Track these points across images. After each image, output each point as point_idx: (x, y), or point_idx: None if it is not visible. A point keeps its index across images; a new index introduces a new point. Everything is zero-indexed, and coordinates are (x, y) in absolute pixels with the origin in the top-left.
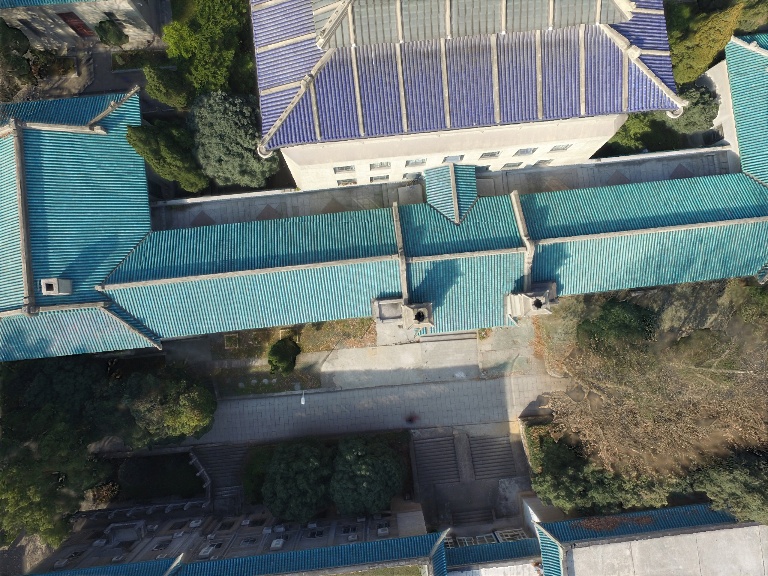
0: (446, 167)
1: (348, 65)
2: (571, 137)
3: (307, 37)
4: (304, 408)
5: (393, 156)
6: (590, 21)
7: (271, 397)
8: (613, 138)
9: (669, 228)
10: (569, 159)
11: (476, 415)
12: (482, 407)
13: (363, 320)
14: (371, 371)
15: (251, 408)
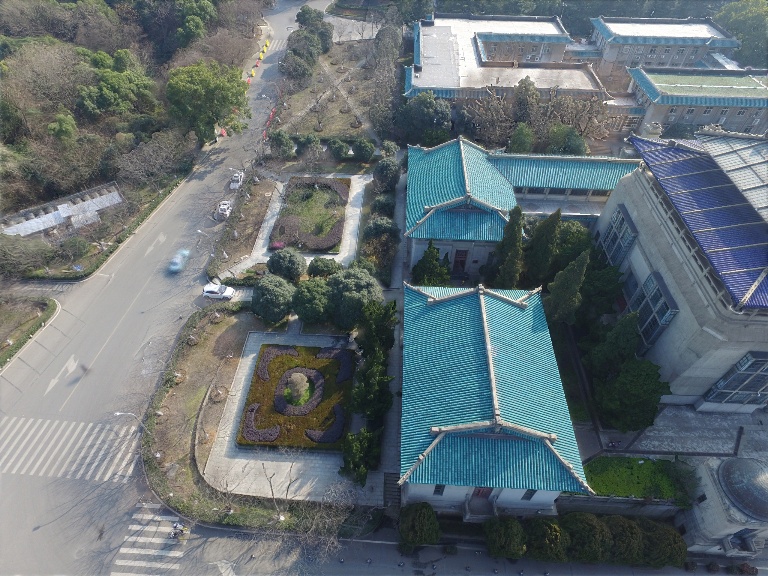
0: None
1: None
2: None
3: None
4: None
5: None
6: None
7: None
8: None
9: (572, 157)
10: None
11: None
12: None
13: None
14: None
15: None
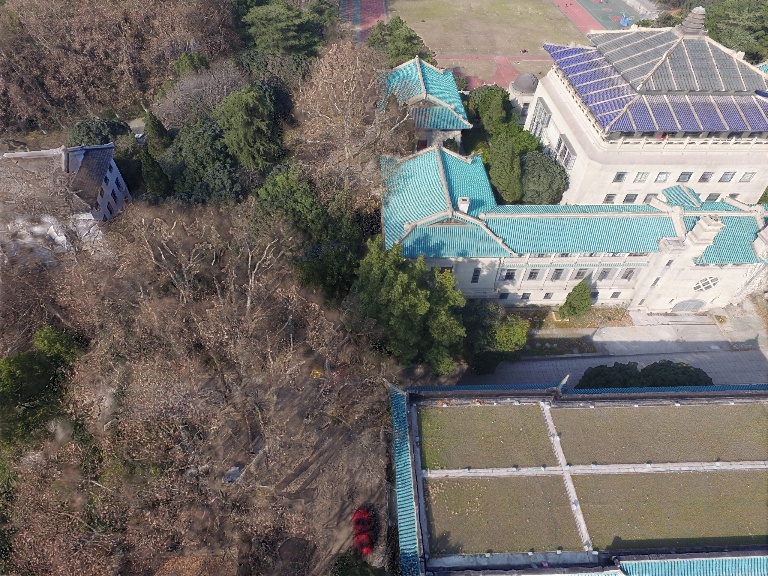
0: (678, 186)
1: (644, 105)
2: (757, 163)
3: (619, 98)
4: (584, 368)
5: (656, 164)
6: (763, 89)
7: (553, 360)
8: (765, 201)
9: None
10: (748, 197)
11: (744, 376)
12: (747, 370)
13: (617, 309)
14: (636, 342)
15: (536, 368)
